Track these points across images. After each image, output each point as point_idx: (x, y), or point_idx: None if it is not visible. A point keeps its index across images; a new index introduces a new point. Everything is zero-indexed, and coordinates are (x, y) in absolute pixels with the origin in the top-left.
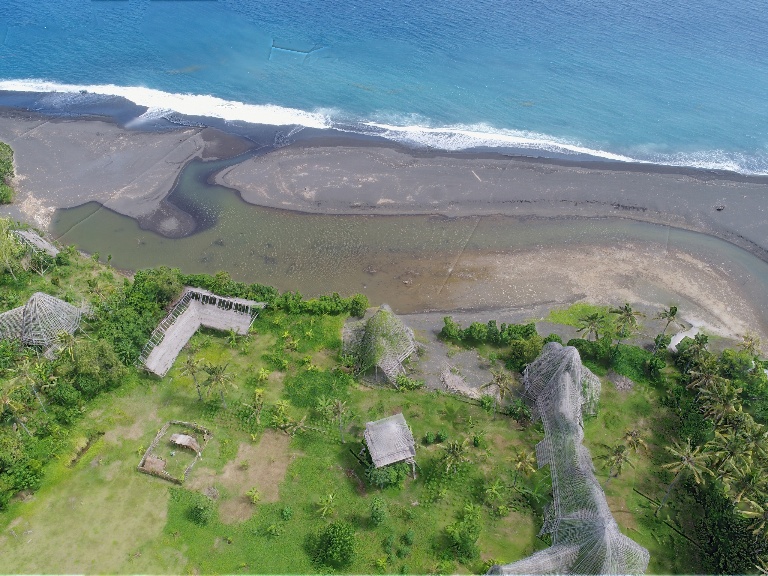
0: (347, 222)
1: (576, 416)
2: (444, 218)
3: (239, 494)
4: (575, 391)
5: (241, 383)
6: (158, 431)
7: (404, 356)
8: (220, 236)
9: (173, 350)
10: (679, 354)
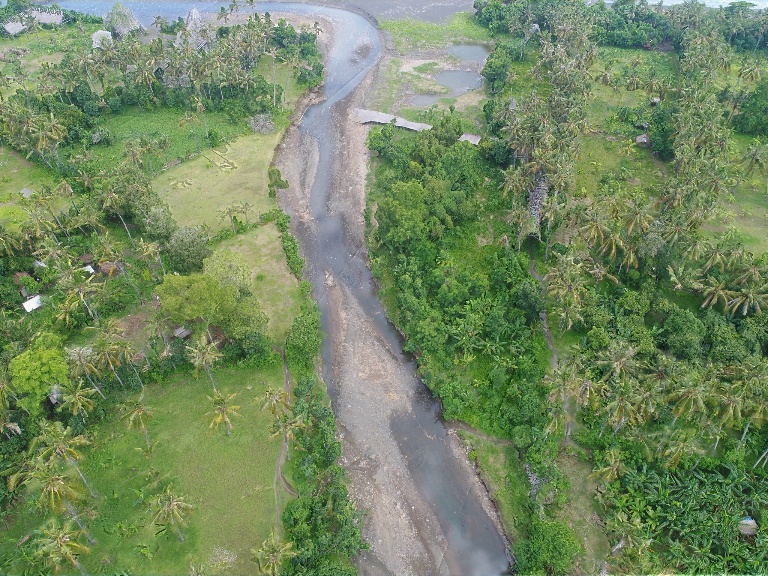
0: (142, 1)
1: (198, 43)
2: (198, 1)
3: (36, 66)
4: (197, 30)
5: None
6: (5, 48)
7: (131, 29)
8: (68, 4)
9: (21, 27)
10: None
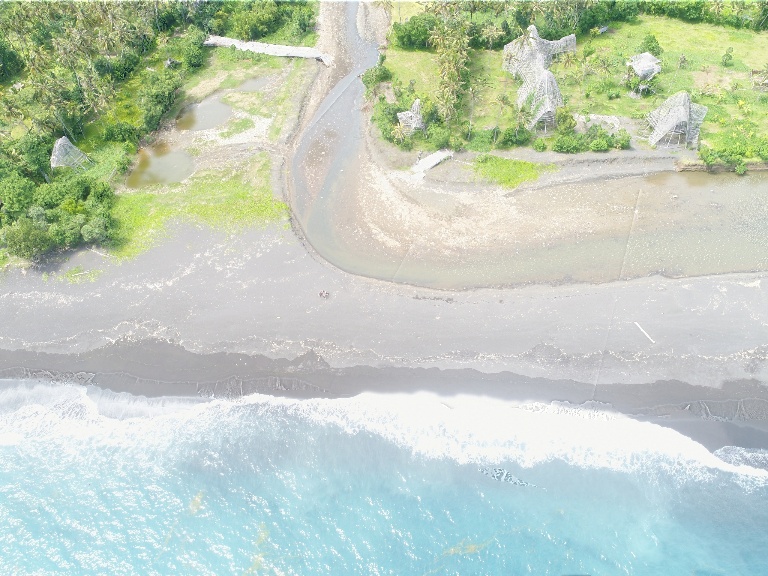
0: None
1: None
2: (665, 273)
3: None
4: None
5: (759, 112)
6: None
7: None
8: None
9: None
10: (446, 142)
